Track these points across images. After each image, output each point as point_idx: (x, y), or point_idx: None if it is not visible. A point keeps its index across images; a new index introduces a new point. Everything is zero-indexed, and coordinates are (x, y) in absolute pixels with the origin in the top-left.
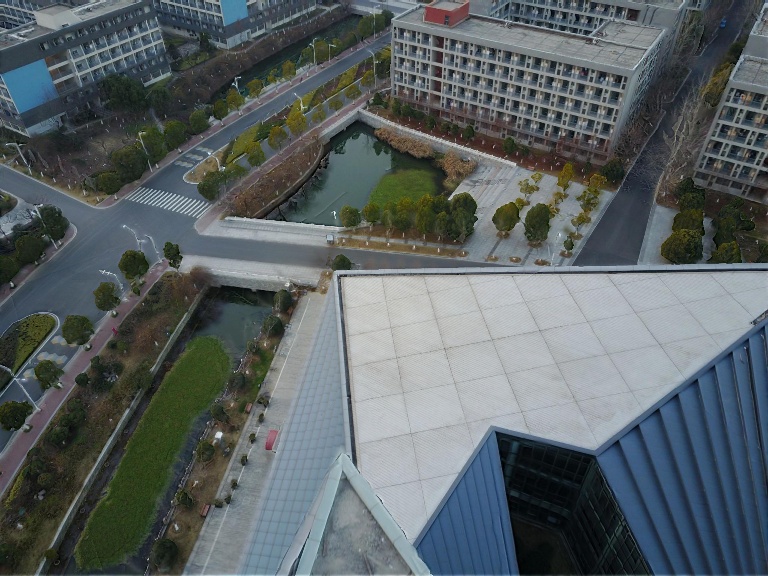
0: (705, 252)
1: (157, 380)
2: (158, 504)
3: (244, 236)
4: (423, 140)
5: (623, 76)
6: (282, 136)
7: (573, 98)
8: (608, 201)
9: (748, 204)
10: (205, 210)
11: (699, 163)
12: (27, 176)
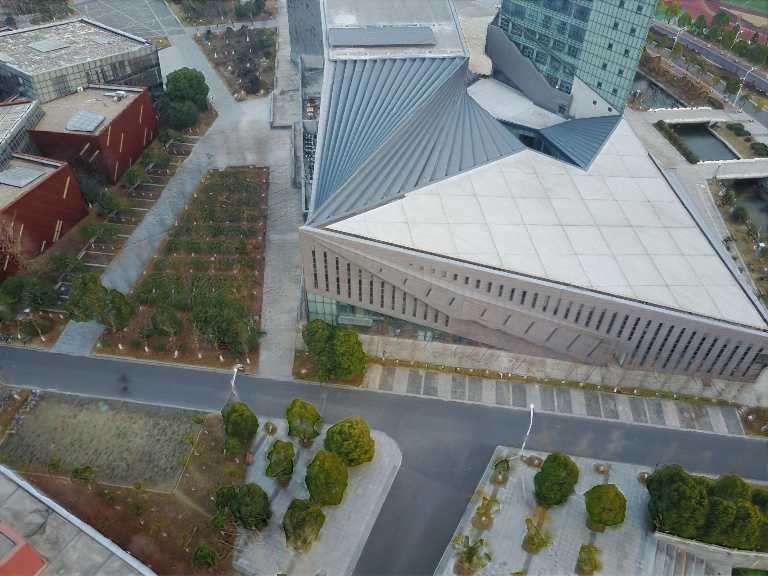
0: (298, 484)
1: None
2: None
3: None
4: None
5: None
6: None
7: None
8: None
9: None
10: None
11: None
12: None
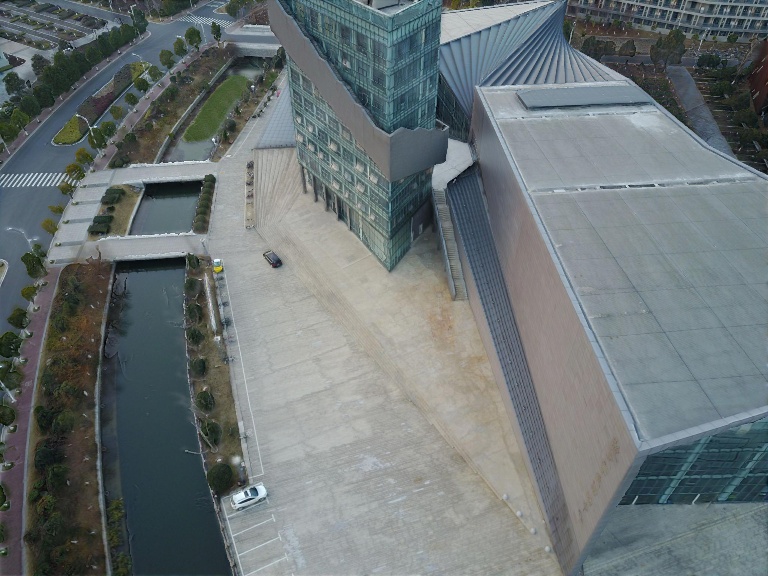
0: None
1: (212, 89)
2: (221, 125)
3: (256, 34)
4: None
5: None
6: None
7: None
8: None
9: None
10: (230, 24)
11: None
12: (110, 11)
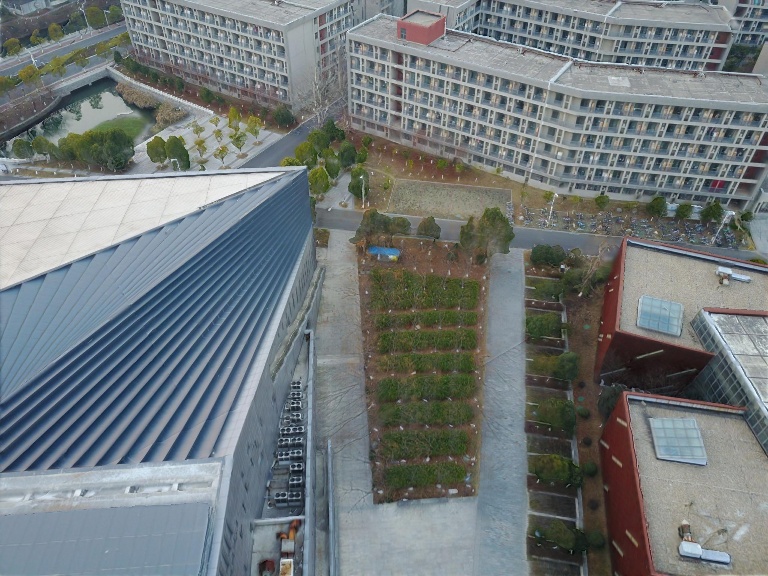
0: None
1: None
2: None
3: None
4: (150, 93)
5: (280, 31)
6: (10, 86)
7: (255, 52)
8: (273, 142)
9: (387, 144)
10: None
11: (350, 109)
12: None
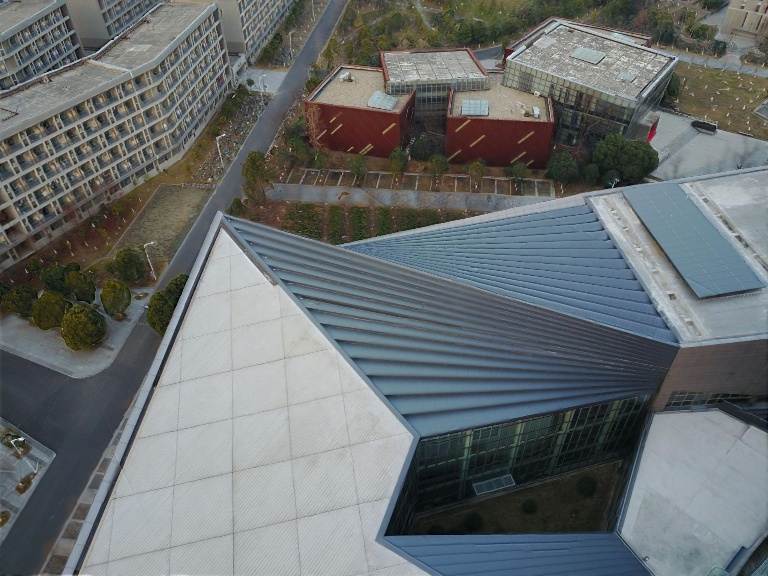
0: None
1: None
2: None
3: None
4: None
5: None
6: None
7: None
8: None
9: None
10: None
11: None
12: None
